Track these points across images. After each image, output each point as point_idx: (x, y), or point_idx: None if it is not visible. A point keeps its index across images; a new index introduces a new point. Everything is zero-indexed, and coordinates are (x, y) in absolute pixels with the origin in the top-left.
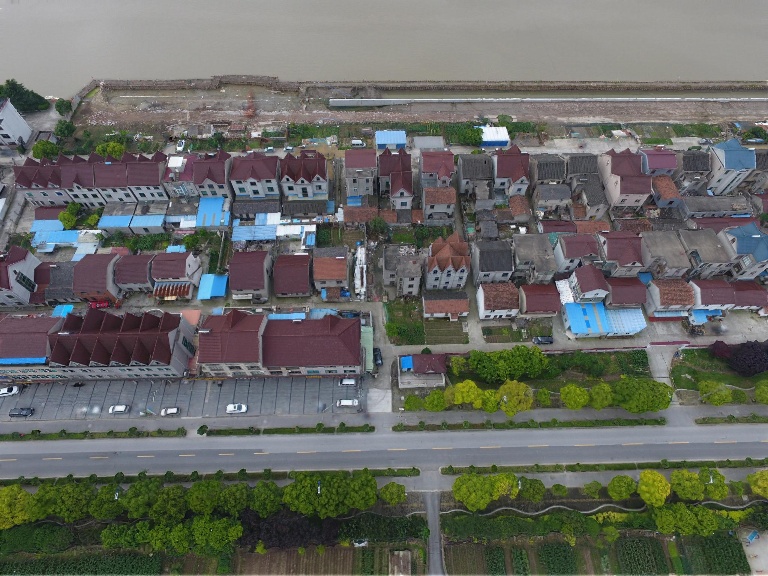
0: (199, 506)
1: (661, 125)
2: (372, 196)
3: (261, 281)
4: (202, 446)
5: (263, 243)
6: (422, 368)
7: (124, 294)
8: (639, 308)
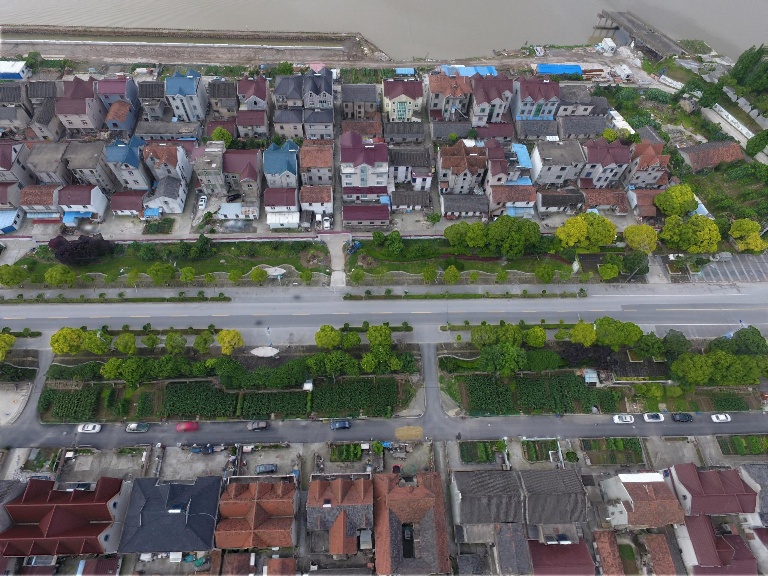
0: None
1: (199, 66)
2: None
3: None
4: None
5: None
6: None
7: None
8: (15, 210)
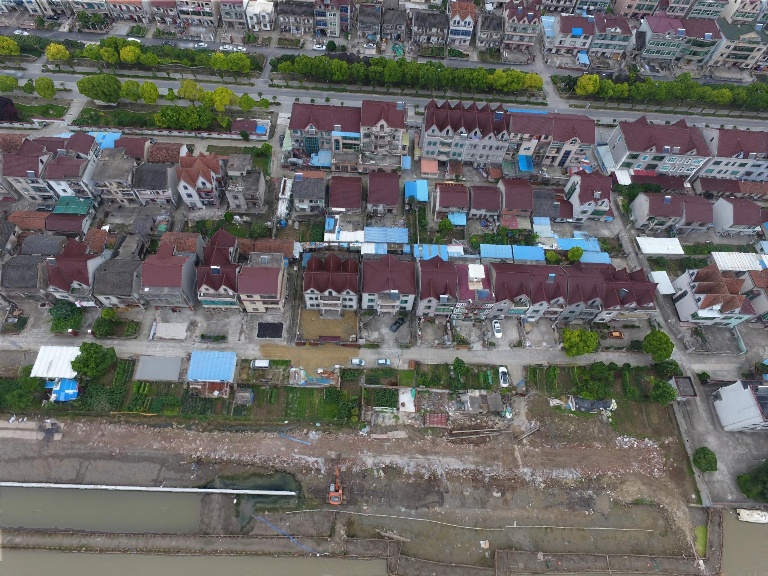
0: None
1: None
2: None
3: None
4: None
5: None
6: None
7: None
8: None
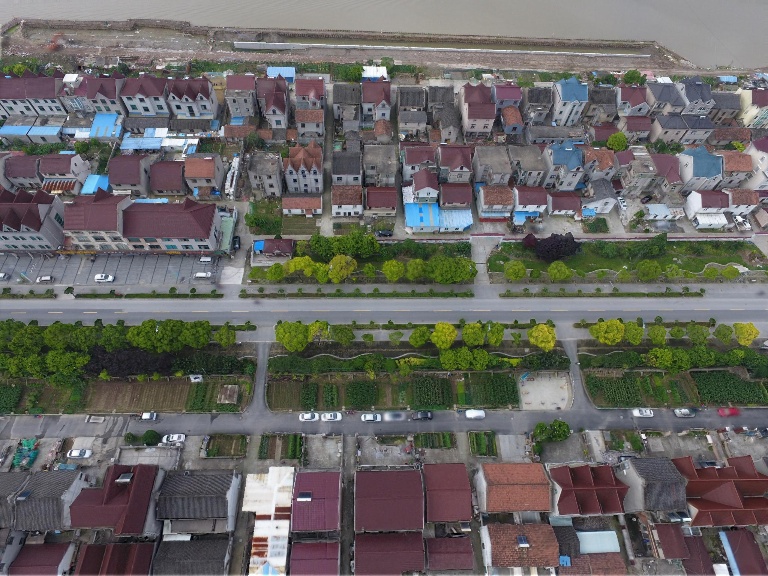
0: (52, 340)
1: (530, 72)
2: (253, 117)
3: (137, 177)
4: (70, 306)
5: (150, 153)
6: (270, 249)
7: (16, 189)
8: (469, 209)
